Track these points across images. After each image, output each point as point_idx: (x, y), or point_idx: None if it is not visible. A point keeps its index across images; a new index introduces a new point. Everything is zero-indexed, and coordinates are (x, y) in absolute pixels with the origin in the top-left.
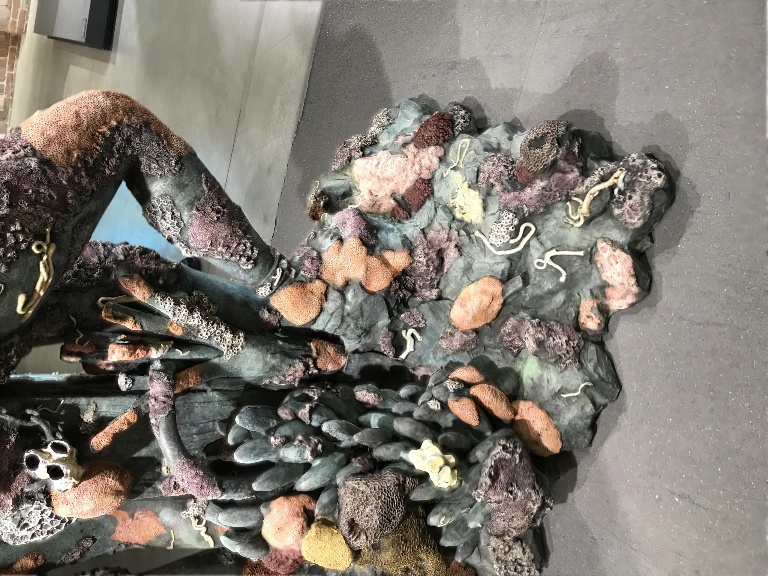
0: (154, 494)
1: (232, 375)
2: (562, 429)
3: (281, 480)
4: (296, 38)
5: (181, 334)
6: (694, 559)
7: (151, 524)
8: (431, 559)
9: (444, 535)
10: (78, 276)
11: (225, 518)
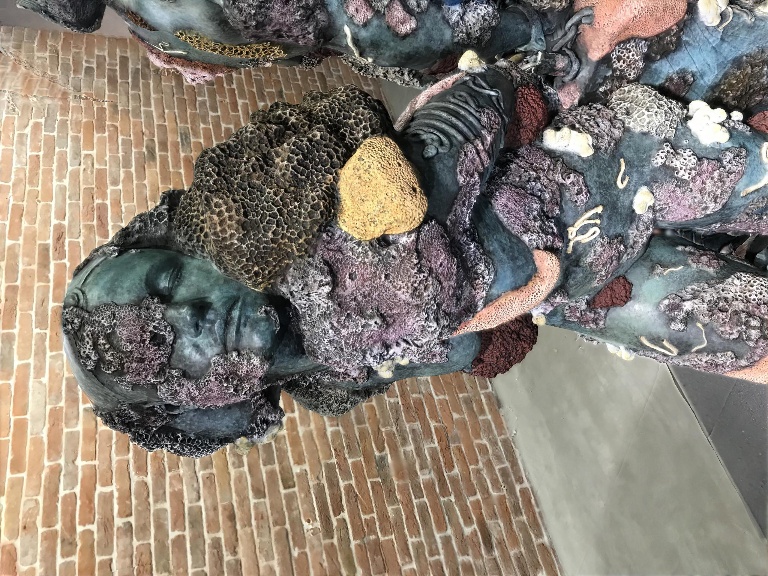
0: None
1: None
2: None
3: None
4: None
5: None
6: None
7: None
8: None
9: None
10: None
11: None
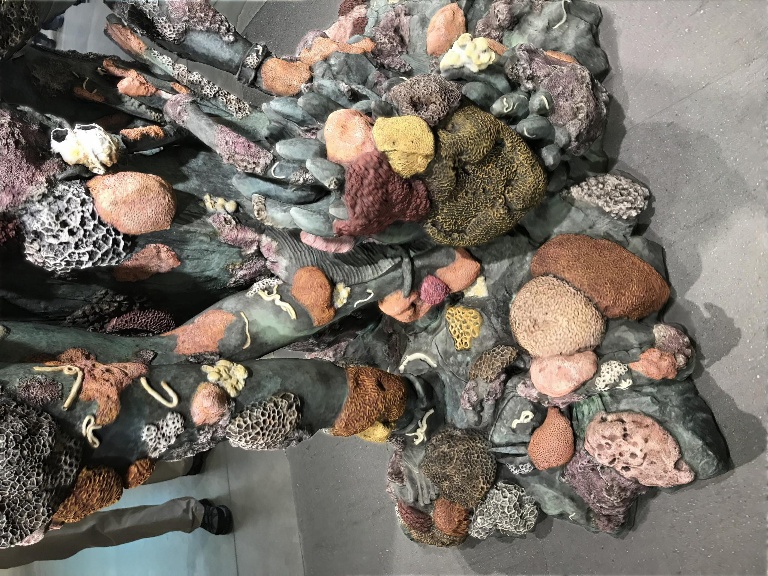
0: (205, 226)
1: (249, 134)
2: (573, 53)
3: None
4: None
5: None
6: (753, 26)
7: (216, 318)
8: (518, 147)
9: (517, 124)
10: (74, 54)
11: (283, 143)
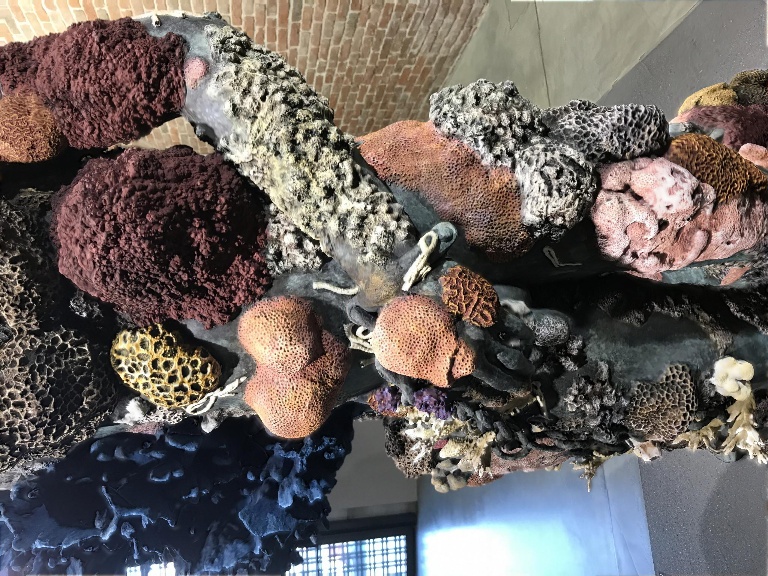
0: None
1: None
2: None
3: None
4: None
5: None
6: None
7: None
8: None
9: None
10: None
11: None
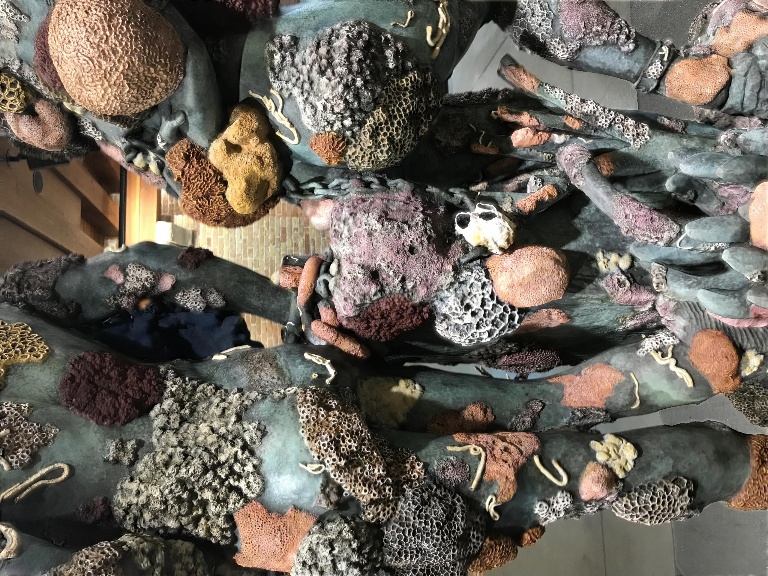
0: (597, 292)
1: (648, 166)
2: None
3: (753, 162)
4: (611, 92)
5: (579, 128)
6: None
7: (604, 374)
8: None
9: None
10: (469, 99)
11: (695, 226)
